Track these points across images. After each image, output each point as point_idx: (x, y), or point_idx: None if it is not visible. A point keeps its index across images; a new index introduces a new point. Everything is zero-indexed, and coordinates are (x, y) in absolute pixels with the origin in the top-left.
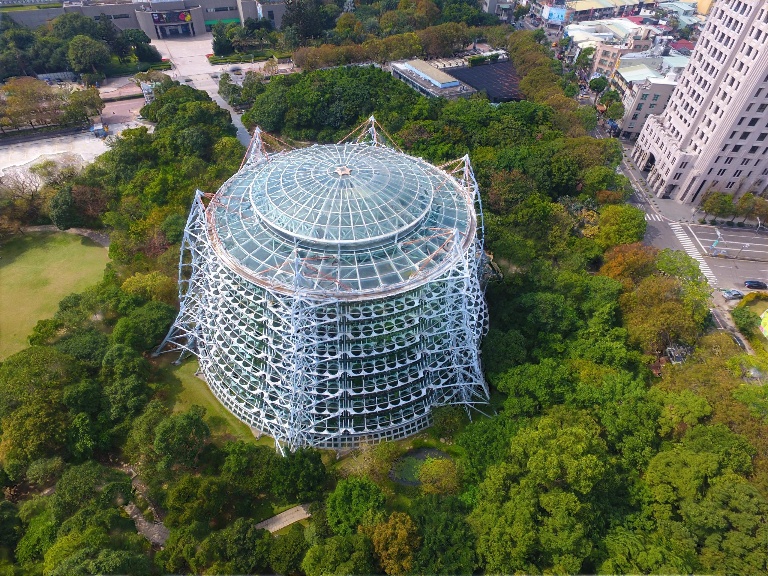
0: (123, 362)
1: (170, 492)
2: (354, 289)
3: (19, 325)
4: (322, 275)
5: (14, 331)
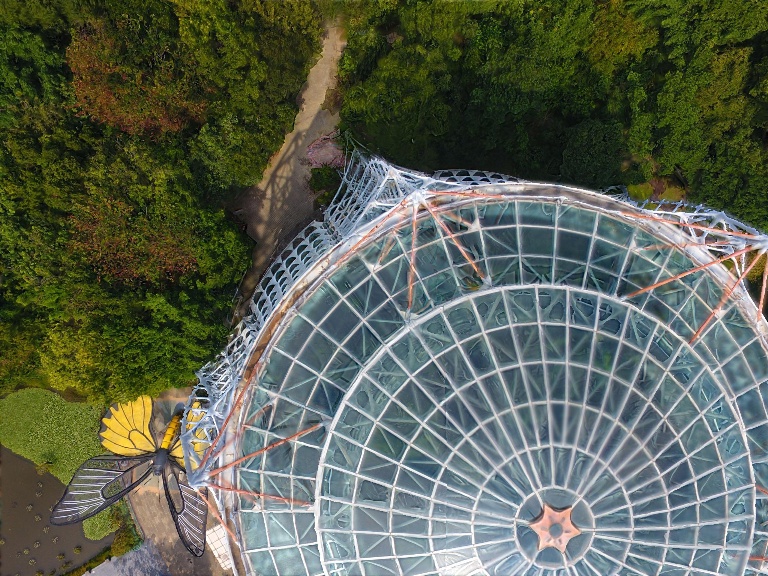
0: None
1: None
2: None
3: None
4: (763, 490)
5: None
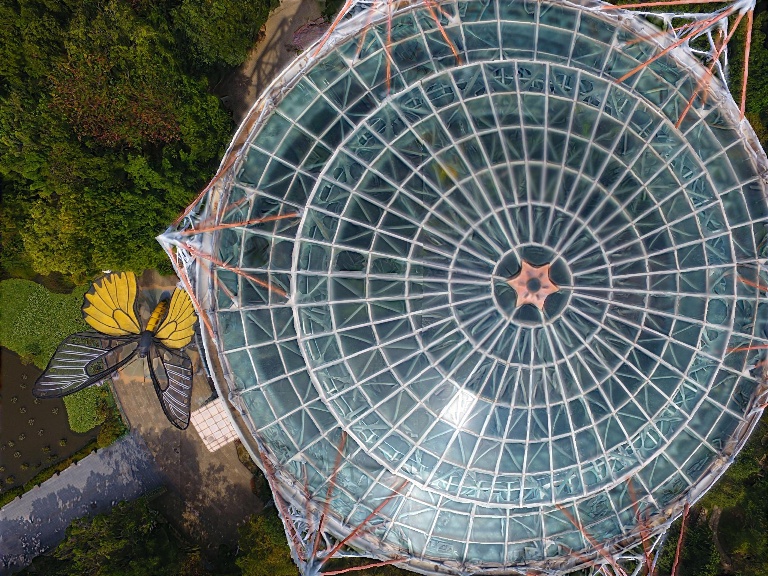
0: (627, 567)
1: (760, 434)
2: (767, 230)
3: None
4: (745, 292)
5: None
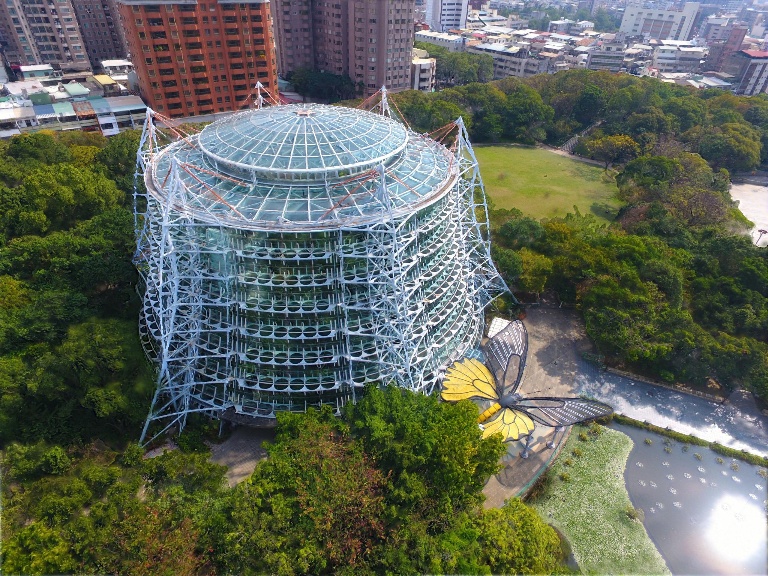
0: None
1: None
2: None
3: (509, 203)
4: None
5: (504, 201)
